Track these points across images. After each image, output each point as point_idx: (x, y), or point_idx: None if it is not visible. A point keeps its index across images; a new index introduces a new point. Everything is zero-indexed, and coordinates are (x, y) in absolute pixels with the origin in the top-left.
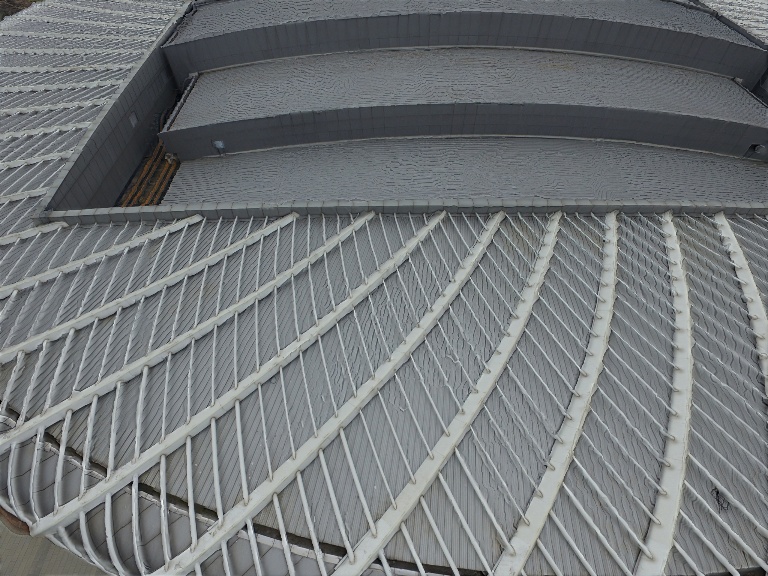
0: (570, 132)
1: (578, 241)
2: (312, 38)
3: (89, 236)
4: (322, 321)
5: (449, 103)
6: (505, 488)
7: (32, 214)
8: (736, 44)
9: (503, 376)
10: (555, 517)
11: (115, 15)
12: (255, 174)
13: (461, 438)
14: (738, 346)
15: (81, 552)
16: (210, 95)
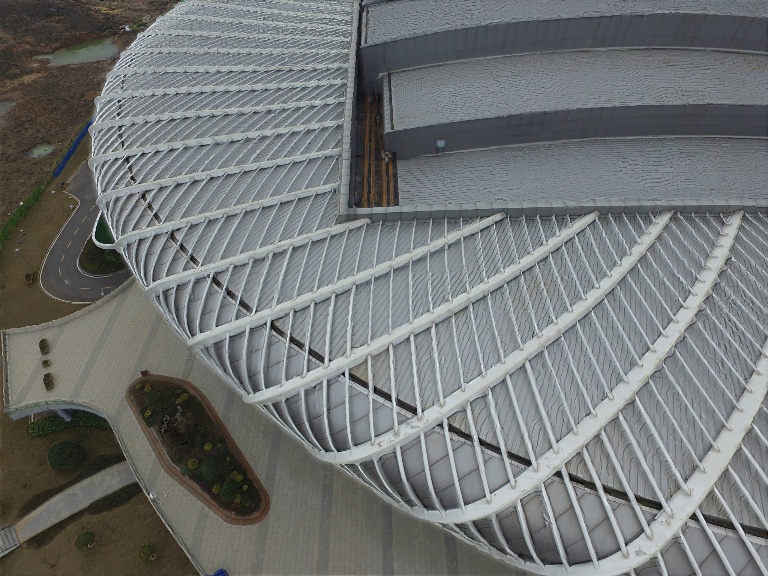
0: None
1: None
2: (510, 39)
3: (399, 233)
4: (679, 317)
5: (681, 104)
6: None
7: (327, 211)
8: None
9: None
10: None
11: (287, 15)
12: (488, 173)
13: None
14: None
15: (506, 539)
16: (417, 95)
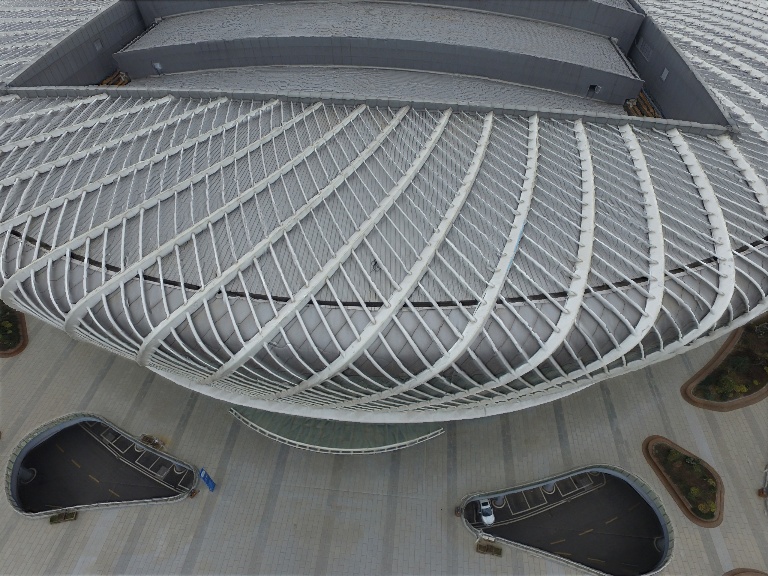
0: (431, 67)
1: (367, 123)
2: None
3: (30, 104)
4: None
5: (327, 36)
6: (232, 245)
7: None
8: (605, 5)
9: (265, 192)
10: (256, 262)
11: None
12: None
13: (217, 219)
14: (444, 188)
15: None
16: (161, 31)
